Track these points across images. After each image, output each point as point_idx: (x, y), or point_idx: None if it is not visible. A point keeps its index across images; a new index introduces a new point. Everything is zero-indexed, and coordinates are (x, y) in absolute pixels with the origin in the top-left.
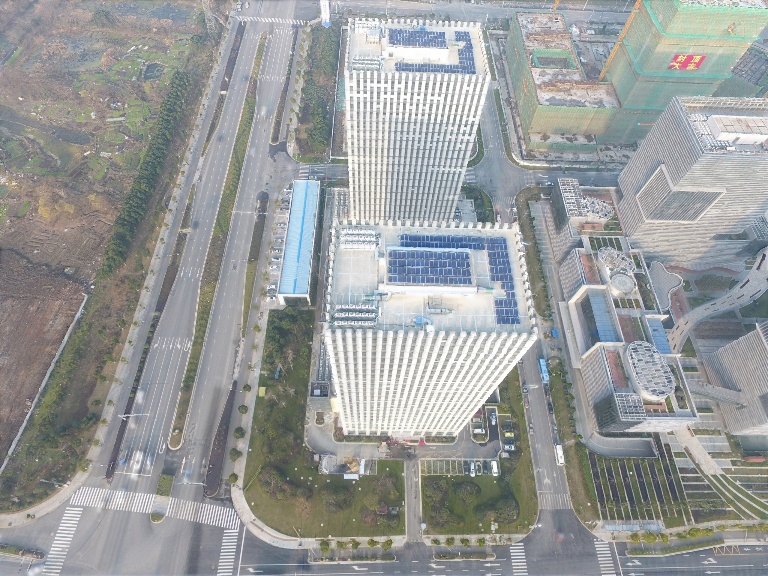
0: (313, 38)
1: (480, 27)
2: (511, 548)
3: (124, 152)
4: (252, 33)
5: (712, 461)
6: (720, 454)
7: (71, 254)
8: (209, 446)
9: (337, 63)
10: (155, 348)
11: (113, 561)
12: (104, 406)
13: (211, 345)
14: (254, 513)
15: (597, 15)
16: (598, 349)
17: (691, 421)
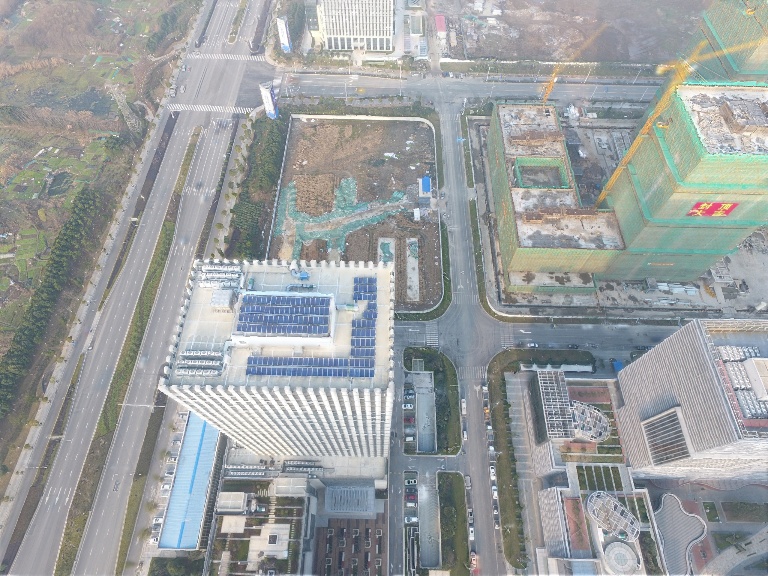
0: (255, 133)
1: (458, 110)
2: None
3: (6, 304)
4: (184, 127)
5: None
6: None
7: None
8: None
9: (280, 168)
10: None
11: None
12: None
13: None
14: None
15: (601, 89)
16: None
17: None
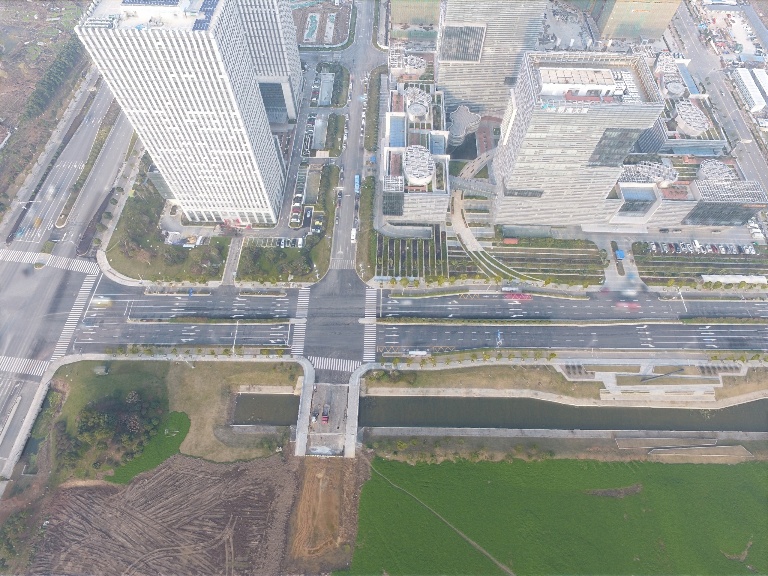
0: None
1: None
2: (300, 290)
3: (57, 42)
4: None
5: (477, 243)
6: (485, 238)
7: (4, 109)
8: (86, 226)
9: None
10: (57, 167)
11: (3, 289)
12: (12, 201)
13: (100, 166)
14: (111, 265)
15: None
16: (386, 153)
17: (443, 197)
